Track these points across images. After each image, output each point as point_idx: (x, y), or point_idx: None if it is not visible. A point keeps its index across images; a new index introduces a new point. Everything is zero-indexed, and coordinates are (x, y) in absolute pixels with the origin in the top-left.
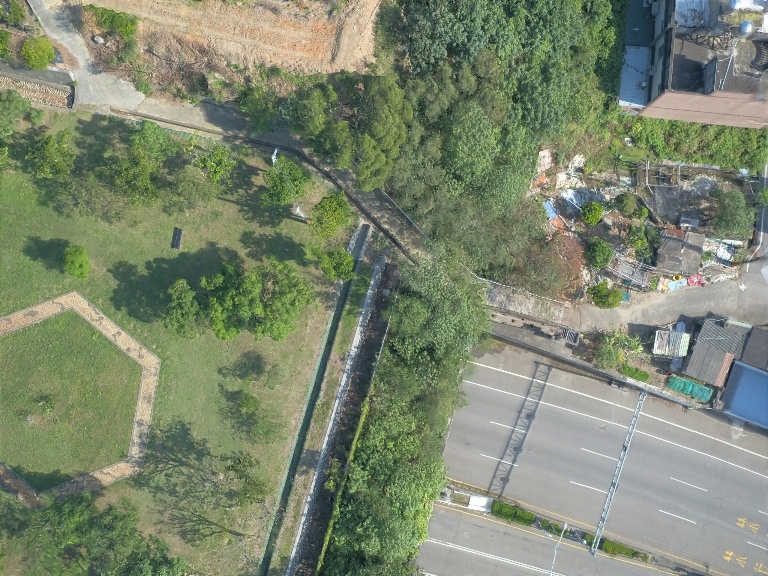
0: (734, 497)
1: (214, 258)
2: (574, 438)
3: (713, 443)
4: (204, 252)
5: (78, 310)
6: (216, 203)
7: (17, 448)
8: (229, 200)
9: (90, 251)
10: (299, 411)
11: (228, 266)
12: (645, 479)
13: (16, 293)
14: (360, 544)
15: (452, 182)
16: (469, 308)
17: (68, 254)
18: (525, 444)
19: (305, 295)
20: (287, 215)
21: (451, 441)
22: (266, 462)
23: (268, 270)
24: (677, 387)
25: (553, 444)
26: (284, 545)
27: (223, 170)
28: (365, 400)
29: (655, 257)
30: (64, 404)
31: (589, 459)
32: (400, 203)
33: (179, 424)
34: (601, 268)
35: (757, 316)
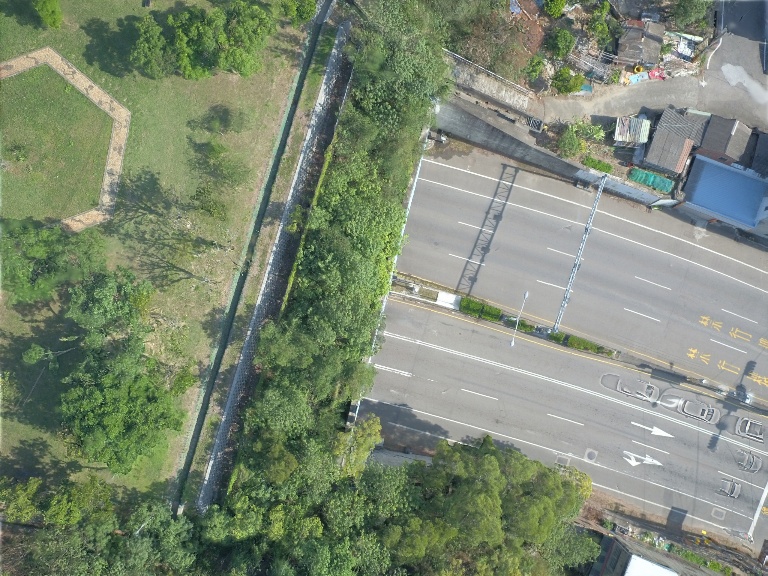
0: (697, 295)
1: None
2: (540, 238)
3: (677, 243)
4: (174, 11)
5: (51, 65)
6: None
7: None
8: None
9: (64, 8)
10: (265, 165)
11: None
12: (610, 278)
13: None
14: (323, 291)
15: None
16: (428, 53)
17: None
18: (492, 244)
19: (267, 23)
20: None
21: (420, 241)
22: (232, 211)
23: (233, 8)
24: (639, 178)
25: (520, 244)
26: (250, 293)
27: None
28: (328, 147)
29: (617, 49)
30: (37, 154)
31: (555, 258)
32: None
33: (148, 174)
34: (564, 61)
35: (717, 112)
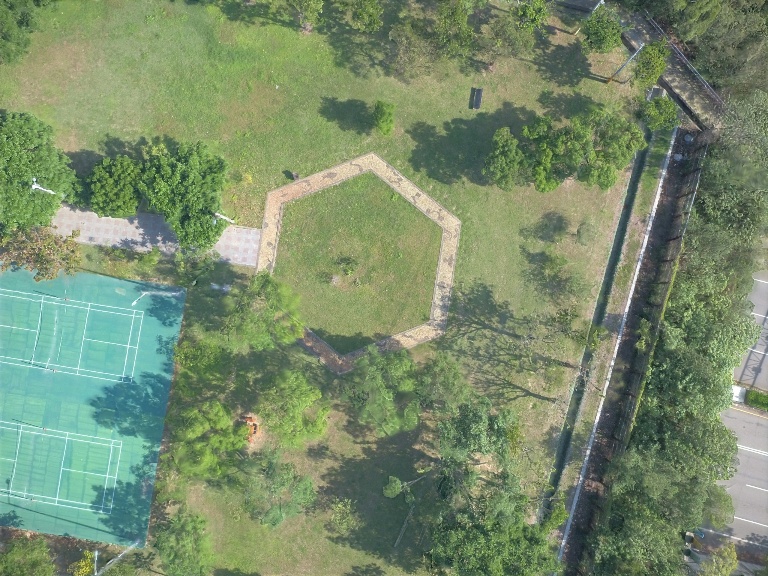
0: None
1: (512, 118)
2: None
3: None
4: (502, 112)
5: (376, 172)
6: (513, 63)
7: (318, 311)
8: (526, 60)
9: None
10: (600, 274)
11: (542, 119)
12: None
13: (314, 155)
14: None
15: (767, 32)
16: None
17: (384, 106)
18: None
19: (640, 138)
20: (586, 74)
21: None
22: None
23: (592, 118)
24: None
25: None
26: (587, 410)
27: (540, 19)
28: (676, 258)
29: None
30: (365, 266)
31: None
32: (694, 64)
33: (481, 286)
34: None
35: None
